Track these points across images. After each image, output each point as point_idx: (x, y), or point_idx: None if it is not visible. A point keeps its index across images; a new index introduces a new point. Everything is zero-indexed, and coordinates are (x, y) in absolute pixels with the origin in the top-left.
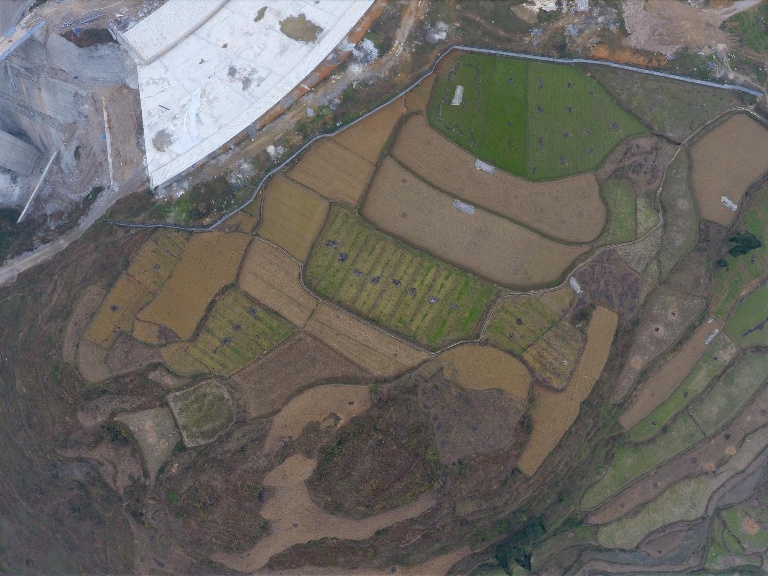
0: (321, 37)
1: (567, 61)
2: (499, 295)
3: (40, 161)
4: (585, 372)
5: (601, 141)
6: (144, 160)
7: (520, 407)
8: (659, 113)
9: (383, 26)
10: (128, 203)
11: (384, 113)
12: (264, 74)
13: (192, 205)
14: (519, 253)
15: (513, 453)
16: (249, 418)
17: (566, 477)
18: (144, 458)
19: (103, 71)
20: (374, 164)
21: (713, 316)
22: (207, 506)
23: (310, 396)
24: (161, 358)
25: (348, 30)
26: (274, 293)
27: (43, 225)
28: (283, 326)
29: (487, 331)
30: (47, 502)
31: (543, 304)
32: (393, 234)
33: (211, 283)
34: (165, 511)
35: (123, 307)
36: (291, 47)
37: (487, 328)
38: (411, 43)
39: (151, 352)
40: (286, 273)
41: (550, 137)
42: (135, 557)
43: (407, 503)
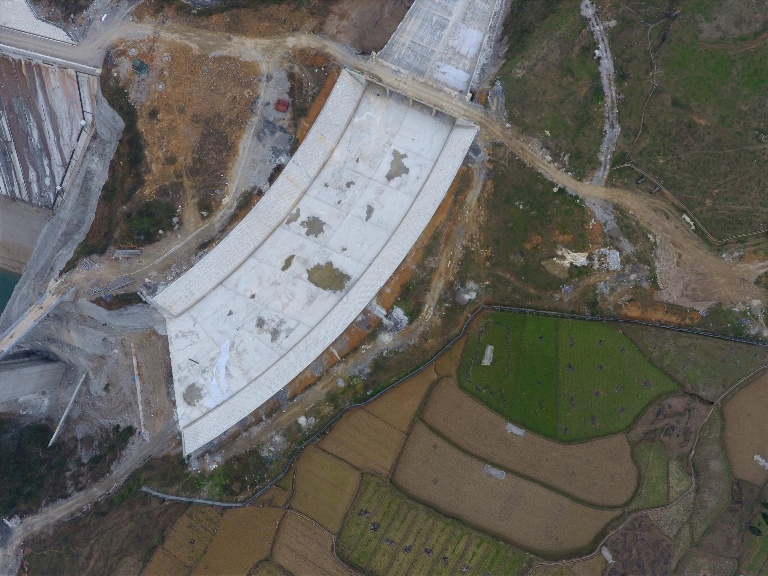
0: (349, 285)
1: (598, 318)
2: (531, 565)
3: (68, 372)
4: None
5: (633, 400)
6: (175, 414)
7: None
8: (692, 371)
9: (413, 291)
10: (161, 469)
11: (414, 380)
12: (292, 325)
13: (225, 480)
14: (550, 518)
15: None
16: None
17: None
18: None
19: (132, 322)
20: (405, 433)
21: (744, 572)
22: None
23: None
24: None
25: (377, 290)
26: (307, 565)
27: (74, 454)
28: None
29: None
30: None
31: (575, 573)
32: (424, 501)
33: (245, 558)
34: None
35: None
36: (319, 296)
37: None
38: (441, 306)
39: None
40: (319, 545)
41: (581, 396)
42: None
43: None
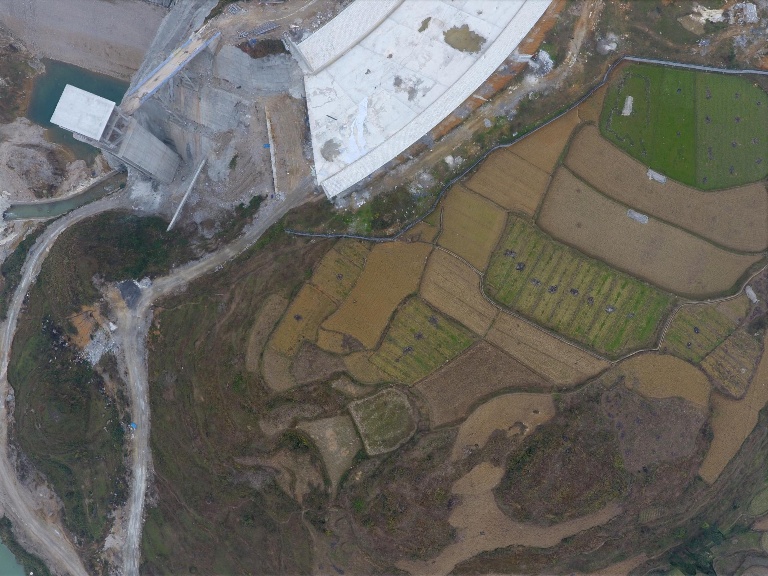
0: (485, 47)
1: (735, 72)
2: (676, 304)
3: (181, 169)
4: (763, 380)
5: None
6: (312, 170)
7: (701, 415)
8: None
9: (557, 37)
10: (305, 213)
11: (559, 124)
12: (429, 84)
13: (374, 215)
14: (693, 262)
15: (695, 461)
16: (433, 426)
17: (740, 484)
18: (326, 466)
19: (269, 81)
20: (550, 174)
21: None
22: (398, 514)
23: (495, 405)
24: (345, 367)
25: (519, 41)
26: (455, 302)
27: (196, 233)
28: (464, 335)
29: (665, 340)
30: (216, 509)
31: (720, 313)
32: (568, 243)
33: (394, 292)
34: (349, 519)
35: (307, 316)
36: (455, 57)
37: (665, 337)
38: (584, 54)
39: (335, 361)
40: (466, 282)
41: (719, 147)
42: (313, 564)
43: (595, 511)
